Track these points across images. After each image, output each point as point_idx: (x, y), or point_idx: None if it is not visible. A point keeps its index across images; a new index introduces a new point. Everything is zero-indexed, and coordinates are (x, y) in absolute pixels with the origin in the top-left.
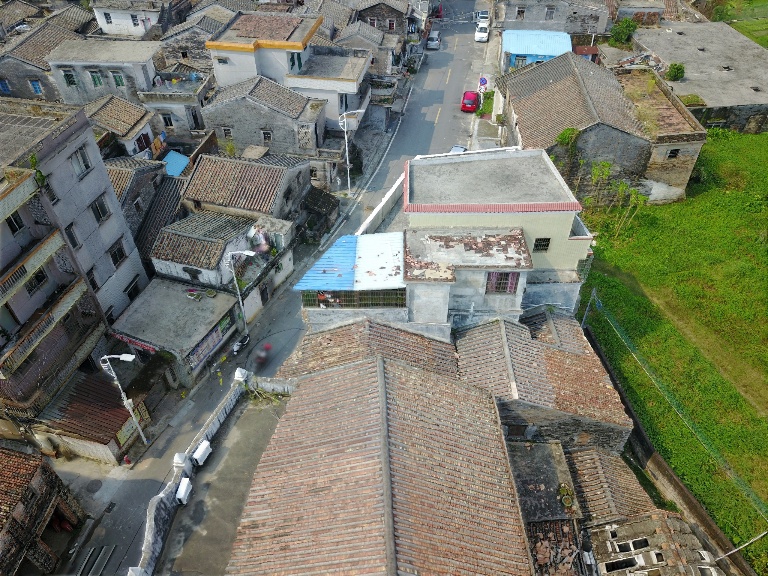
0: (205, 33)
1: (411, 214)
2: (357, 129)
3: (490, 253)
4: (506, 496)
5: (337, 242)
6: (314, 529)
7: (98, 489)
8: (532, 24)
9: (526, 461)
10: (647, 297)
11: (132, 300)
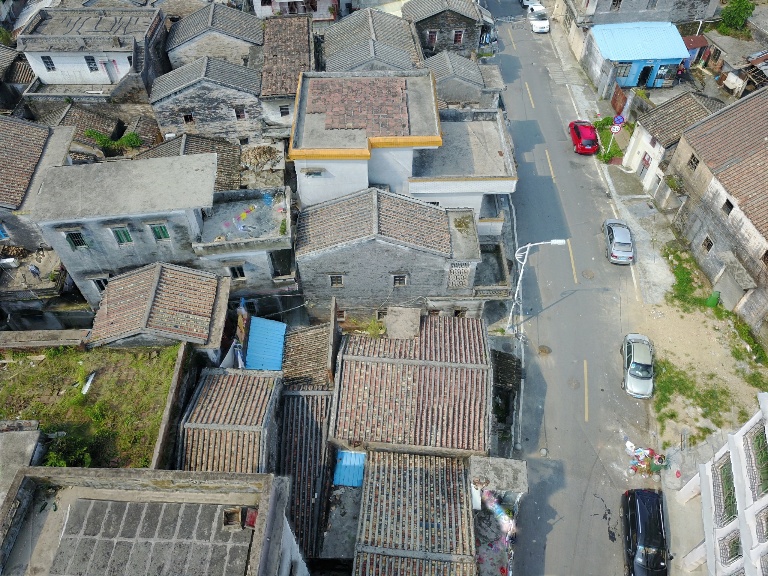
0: (219, 87)
1: None
2: None
3: None
4: None
5: None
6: None
7: None
8: (629, 15)
9: None
10: None
11: None
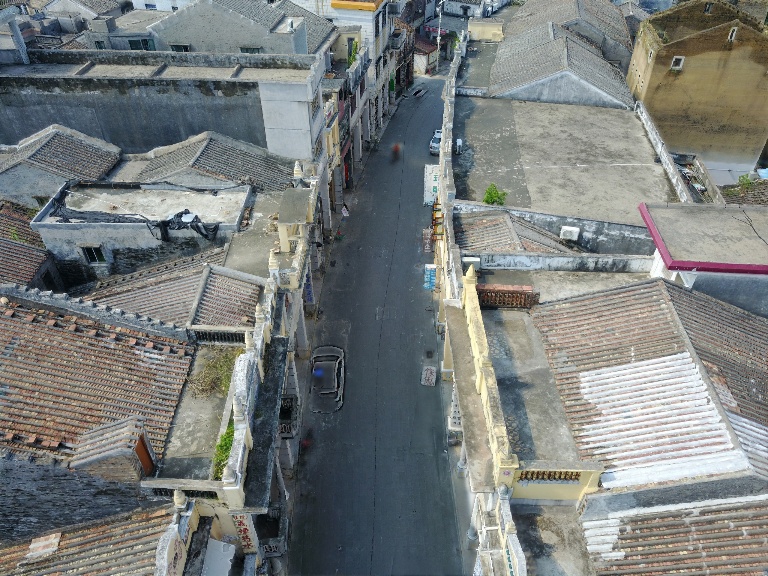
0: None
1: None
2: None
3: None
4: (621, 22)
5: None
6: None
7: (417, 78)
8: None
9: None
10: None
11: (432, 19)
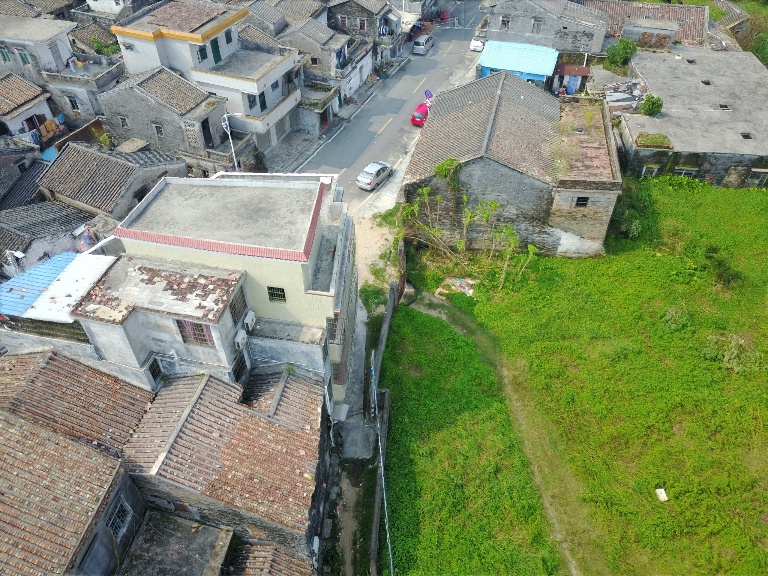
0: None
1: (123, 239)
2: (289, 132)
3: (186, 297)
4: None
5: (52, 259)
6: None
7: None
8: (517, 36)
9: (180, 545)
10: (496, 366)
11: None
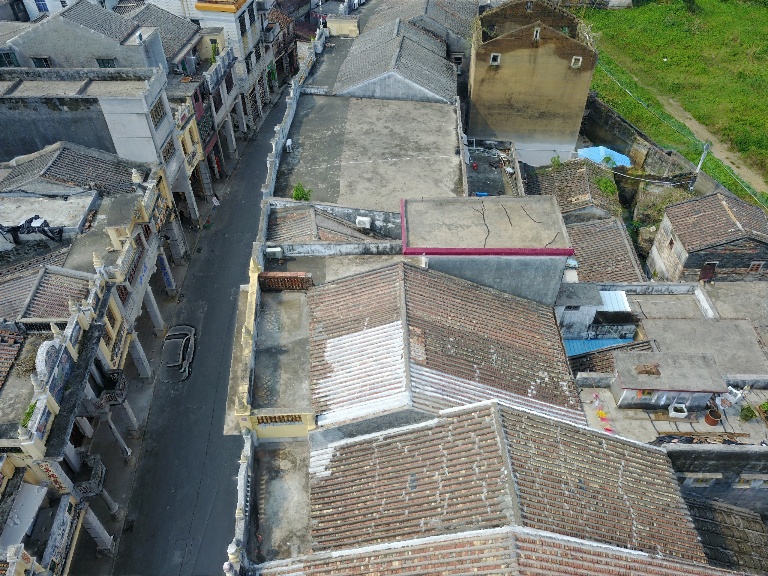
0: None
1: None
2: None
3: None
4: (474, 13)
5: None
6: (402, 3)
7: None
8: None
9: None
10: None
11: None
